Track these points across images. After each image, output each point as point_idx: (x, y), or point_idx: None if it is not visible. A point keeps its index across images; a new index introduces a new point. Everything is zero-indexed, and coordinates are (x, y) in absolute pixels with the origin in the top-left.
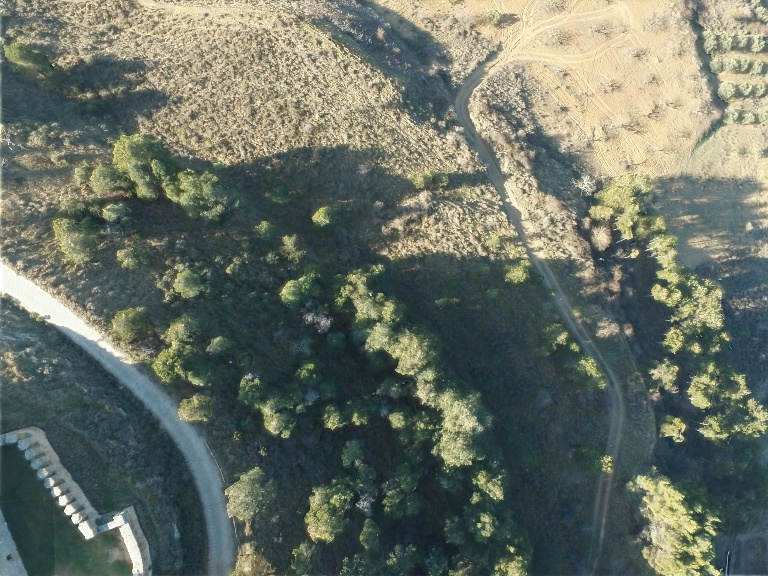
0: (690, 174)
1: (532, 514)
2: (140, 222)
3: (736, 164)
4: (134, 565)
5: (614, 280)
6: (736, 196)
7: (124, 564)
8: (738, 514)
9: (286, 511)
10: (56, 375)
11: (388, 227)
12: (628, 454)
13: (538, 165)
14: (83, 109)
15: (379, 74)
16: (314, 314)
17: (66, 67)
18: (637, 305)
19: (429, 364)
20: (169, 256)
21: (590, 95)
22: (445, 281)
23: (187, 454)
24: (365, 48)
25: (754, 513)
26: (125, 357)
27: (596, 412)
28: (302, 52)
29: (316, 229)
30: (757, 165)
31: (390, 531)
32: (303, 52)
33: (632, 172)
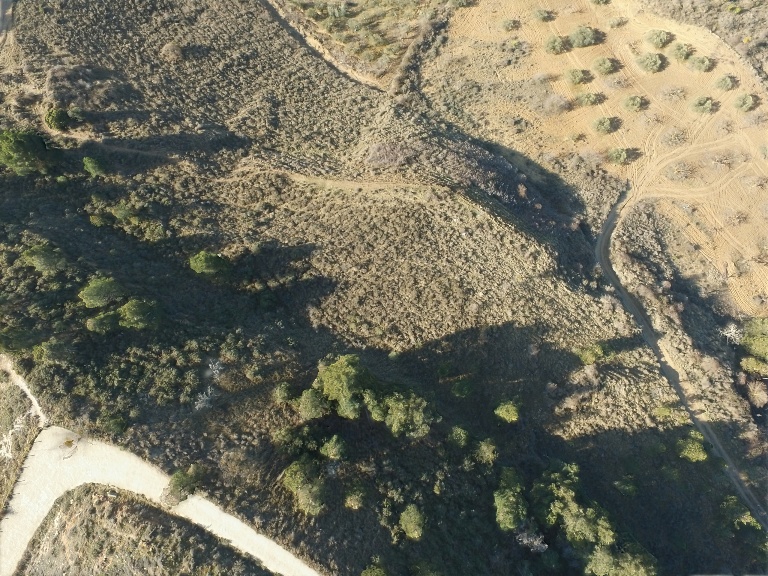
0: None
1: None
2: None
3: None
4: None
5: None
6: None
7: None
8: None
9: None
10: None
11: (561, 407)
12: None
13: (684, 315)
14: (255, 302)
15: (533, 242)
16: (527, 534)
17: (232, 257)
18: None
19: None
20: (380, 481)
21: (719, 229)
22: (619, 458)
23: None
24: (512, 210)
25: None
26: None
27: None
28: (459, 226)
29: (498, 420)
30: None
31: None
32: (460, 226)
33: (765, 306)
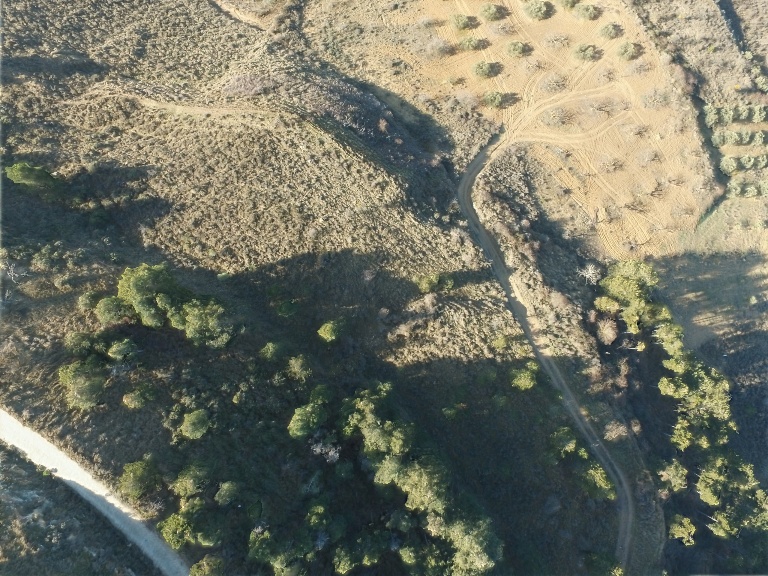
0: (694, 251)
1: None
2: (145, 350)
3: (739, 237)
4: None
5: (621, 375)
6: (740, 269)
7: None
8: None
9: None
10: (64, 541)
11: (394, 334)
12: (638, 555)
13: (542, 255)
14: (86, 220)
15: (382, 172)
16: (322, 444)
17: (68, 176)
18: (644, 396)
19: (439, 495)
20: (175, 388)
21: (593, 175)
22: (452, 386)
23: None
24: (367, 143)
25: None
26: (133, 513)
27: (605, 514)
28: (305, 153)
29: (322, 342)
30: (760, 236)
31: None
32: (306, 153)
33: (636, 253)
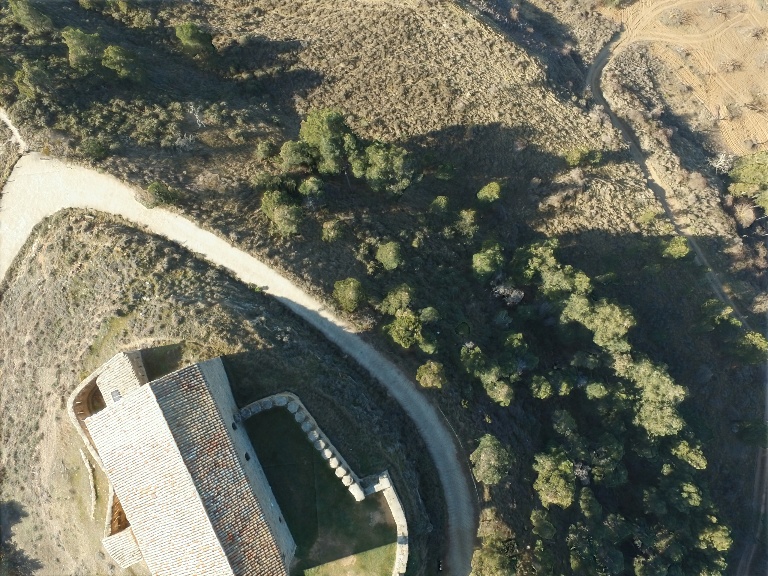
0: None
1: None
2: None
3: None
4: (399, 528)
5: (760, 257)
6: None
7: (386, 527)
8: None
9: (513, 478)
10: (292, 343)
11: (545, 204)
12: None
13: (673, 143)
14: (241, 89)
15: (523, 53)
16: (504, 286)
17: (220, 48)
18: None
19: None
20: (359, 230)
21: (712, 75)
22: (601, 257)
23: (418, 421)
24: (503, 28)
25: None
26: (348, 326)
27: (752, 388)
28: (448, 31)
29: (480, 205)
30: None
31: (599, 501)
32: (449, 31)
33: (757, 151)
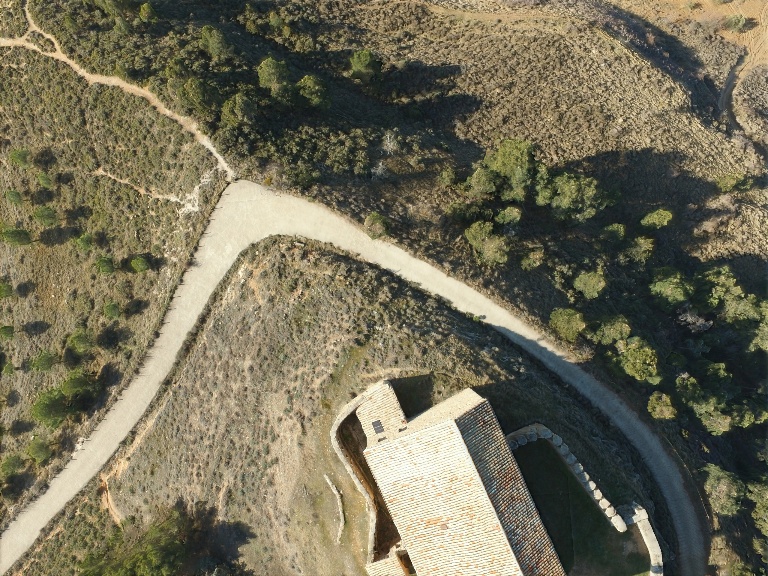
0: None
1: None
2: None
3: None
4: (654, 557)
5: None
6: None
7: (639, 557)
8: None
9: None
10: (526, 373)
11: (700, 229)
12: None
13: None
14: (403, 114)
15: (669, 79)
16: (690, 315)
17: None
18: None
19: None
20: (548, 258)
21: None
22: (754, 282)
23: (643, 451)
24: (644, 53)
25: None
26: (567, 356)
27: None
28: (597, 57)
29: (643, 231)
30: None
31: None
32: (598, 57)
33: None
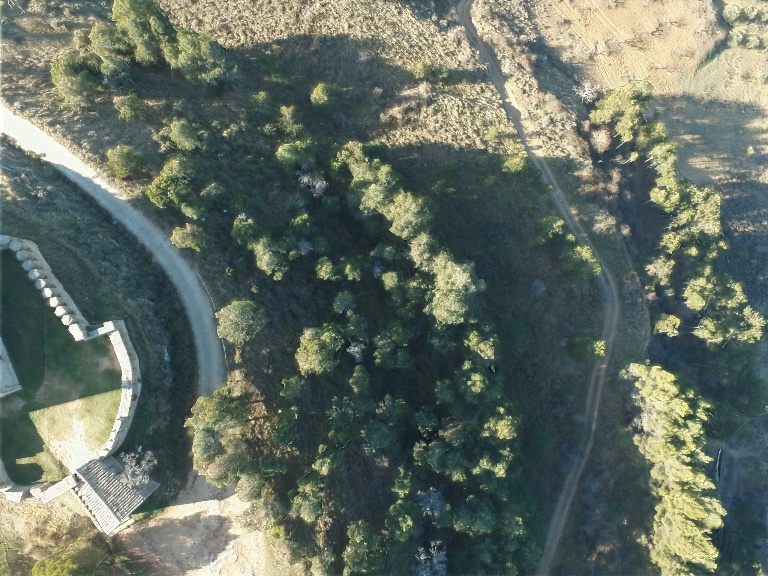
0: (692, 94)
1: (524, 402)
2: (138, 85)
3: (739, 88)
4: (123, 372)
5: (612, 181)
6: (738, 120)
7: (113, 373)
8: (731, 415)
9: (277, 349)
10: (50, 200)
11: (387, 114)
12: (622, 350)
13: (539, 71)
14: None
15: None
16: (310, 177)
17: None
18: (635, 211)
19: (423, 228)
20: (166, 116)
21: (594, 10)
22: (442, 171)
23: (179, 286)
24: None
25: (747, 417)
26: (119, 193)
27: (591, 307)
28: None
29: (314, 110)
30: (760, 91)
31: (380, 384)
32: None
33: None
